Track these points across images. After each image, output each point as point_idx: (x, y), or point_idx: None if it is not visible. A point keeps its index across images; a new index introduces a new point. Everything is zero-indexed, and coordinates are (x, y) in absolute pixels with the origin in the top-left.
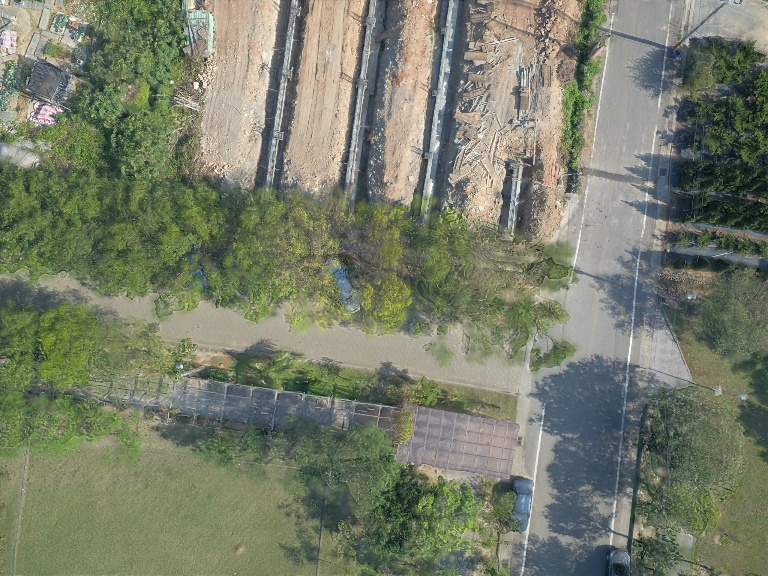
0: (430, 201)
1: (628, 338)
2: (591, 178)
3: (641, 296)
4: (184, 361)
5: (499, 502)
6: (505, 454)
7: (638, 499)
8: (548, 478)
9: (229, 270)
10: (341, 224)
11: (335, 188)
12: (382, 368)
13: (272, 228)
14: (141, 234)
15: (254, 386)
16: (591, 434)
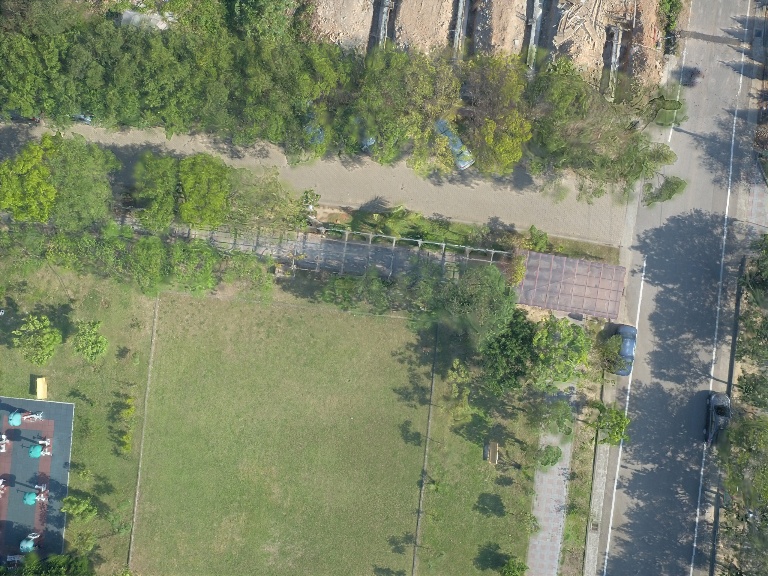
0: (533, 65)
1: (726, 192)
2: (689, 40)
3: (738, 152)
4: (307, 211)
5: (605, 344)
6: (612, 296)
7: (737, 346)
8: (649, 326)
9: (350, 124)
10: (462, 68)
11: (443, 55)
12: (490, 223)
13: (398, 72)
14: (274, 83)
15: (373, 234)
16: (691, 284)
